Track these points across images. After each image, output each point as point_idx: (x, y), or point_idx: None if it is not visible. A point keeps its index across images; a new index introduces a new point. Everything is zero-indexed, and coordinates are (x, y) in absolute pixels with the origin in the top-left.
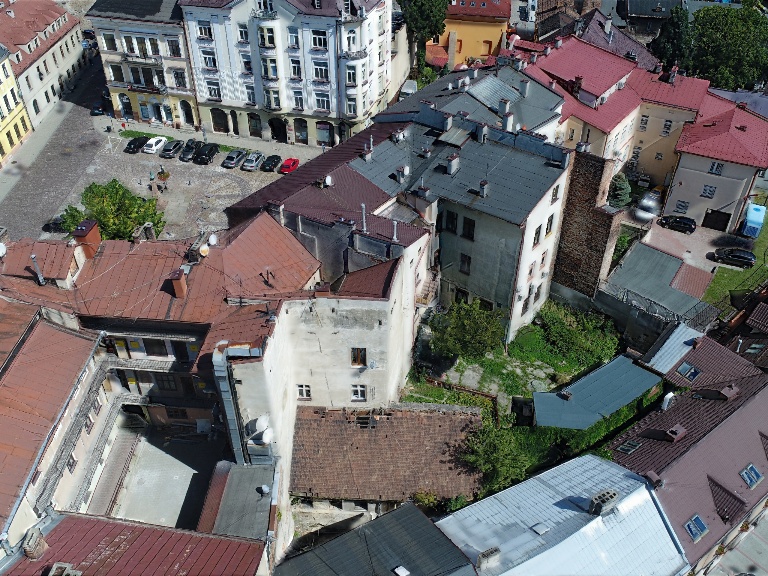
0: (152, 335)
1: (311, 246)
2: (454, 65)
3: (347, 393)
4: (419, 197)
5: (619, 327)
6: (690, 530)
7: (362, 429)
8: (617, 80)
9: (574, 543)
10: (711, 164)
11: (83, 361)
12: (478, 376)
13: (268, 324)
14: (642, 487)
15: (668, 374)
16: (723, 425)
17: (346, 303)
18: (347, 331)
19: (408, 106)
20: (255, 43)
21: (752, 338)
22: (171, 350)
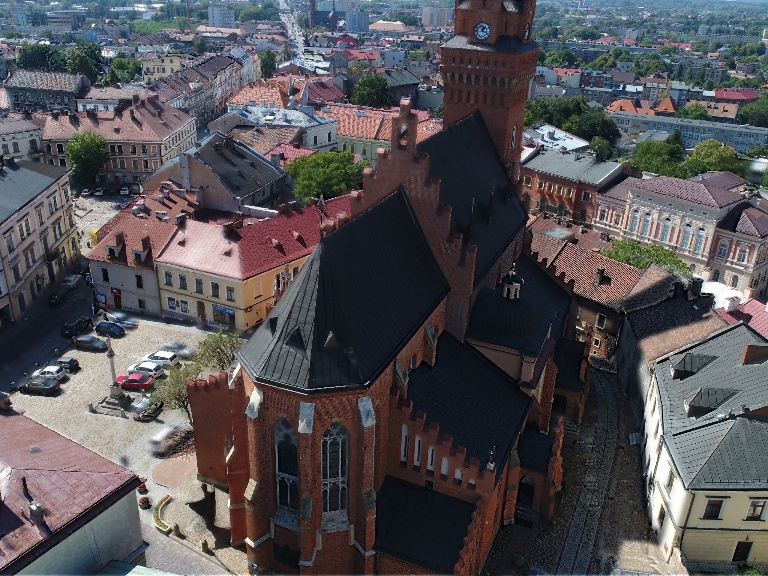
0: None
1: None
2: None
3: None
4: None
5: None
6: None
7: None
8: None
9: None
10: None
11: None
12: None
13: None
14: None
15: None
16: None
17: None
18: None
19: None
20: None
21: None
22: None
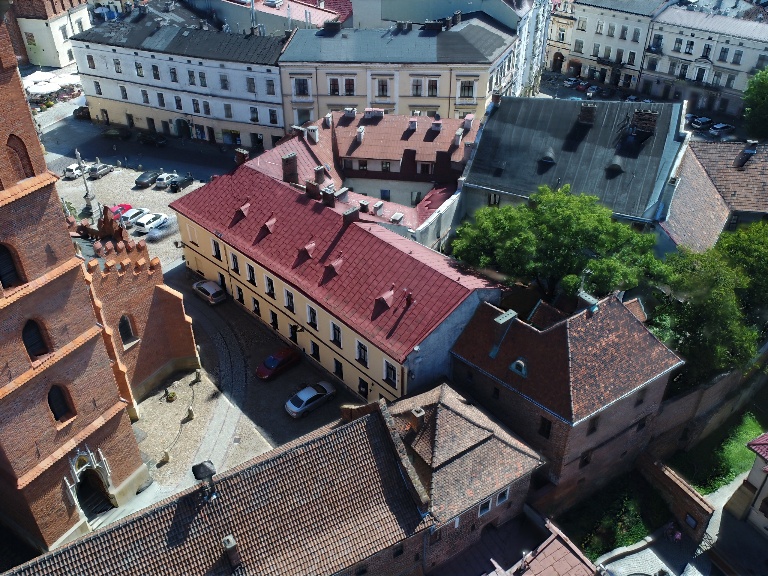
0: None
1: None
2: None
3: None
4: None
5: None
6: None
7: None
8: None
9: None
10: None
11: None
12: None
13: None
14: None
15: None
16: None
17: None
18: None
19: (645, 6)
20: (531, 31)
21: None
22: None
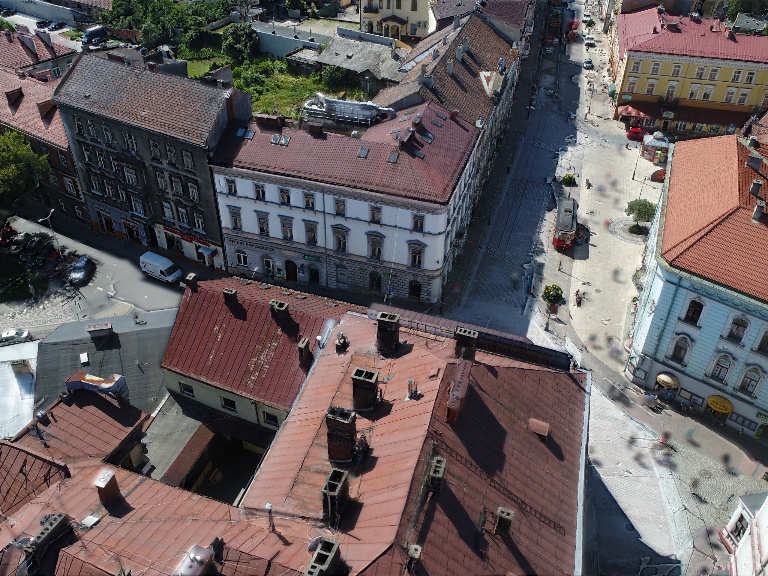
0: None
1: None
2: None
3: None
4: None
5: None
6: None
7: None
8: None
9: None
10: None
11: (253, 487)
12: None
13: (50, 415)
14: None
15: None
16: None
17: None
18: None
19: None
20: None
21: None
22: None
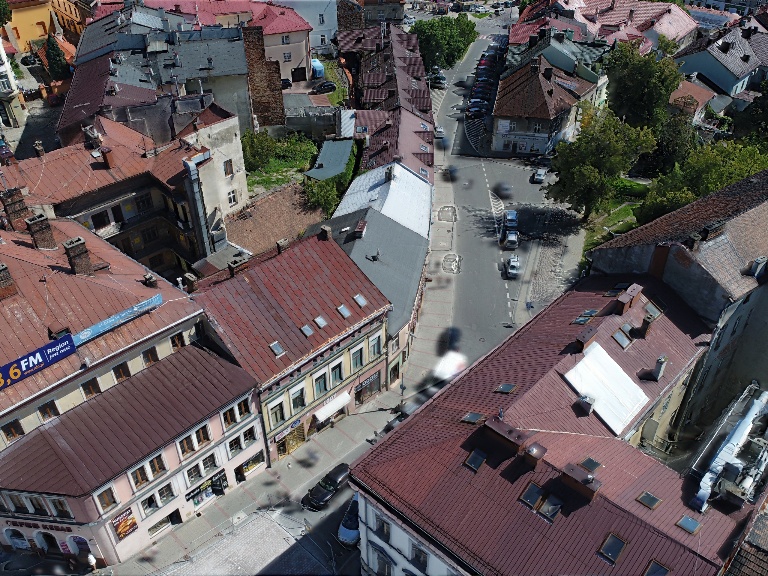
0: (105, 204)
1: (142, 128)
2: (19, 52)
3: (227, 201)
4: (174, 84)
5: (308, 135)
6: (423, 174)
7: (246, 220)
8: (195, 4)
9: (393, 192)
10: (282, 38)
11: None
12: (263, 188)
13: (190, 149)
14: (396, 164)
15: (354, 136)
16: (400, 132)
17: (215, 128)
18: (219, 150)
19: (95, 46)
20: None
21: (371, 109)
22: (112, 218)
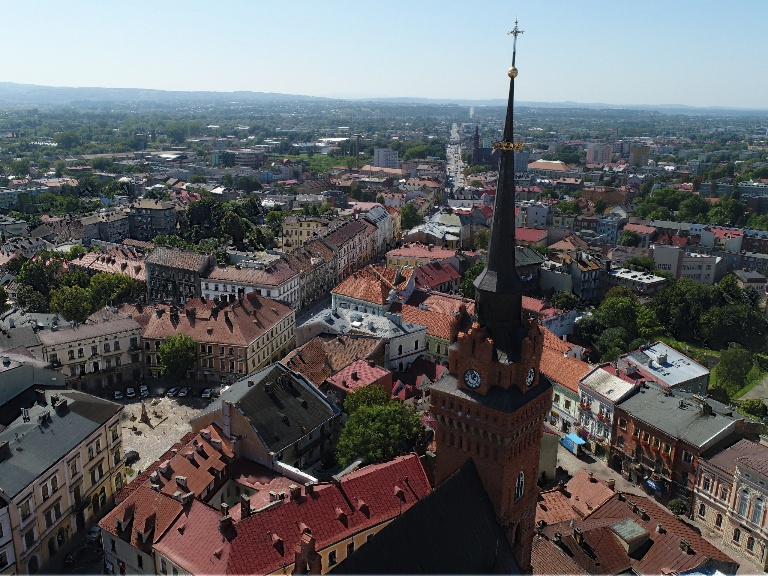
0: None
1: None
2: None
3: None
4: None
5: None
6: None
7: None
8: None
9: None
10: None
11: None
12: None
13: None
14: None
15: None
16: None
17: None
18: None
19: (26, 340)
20: None
21: None
22: None
